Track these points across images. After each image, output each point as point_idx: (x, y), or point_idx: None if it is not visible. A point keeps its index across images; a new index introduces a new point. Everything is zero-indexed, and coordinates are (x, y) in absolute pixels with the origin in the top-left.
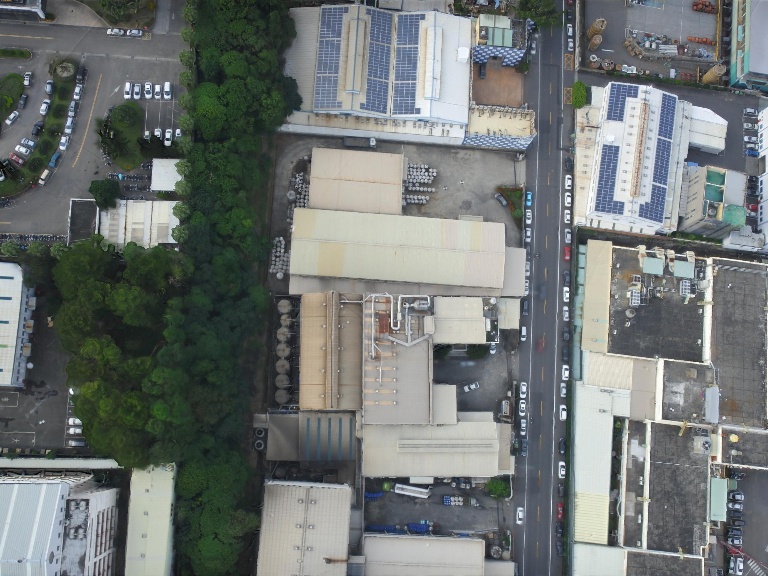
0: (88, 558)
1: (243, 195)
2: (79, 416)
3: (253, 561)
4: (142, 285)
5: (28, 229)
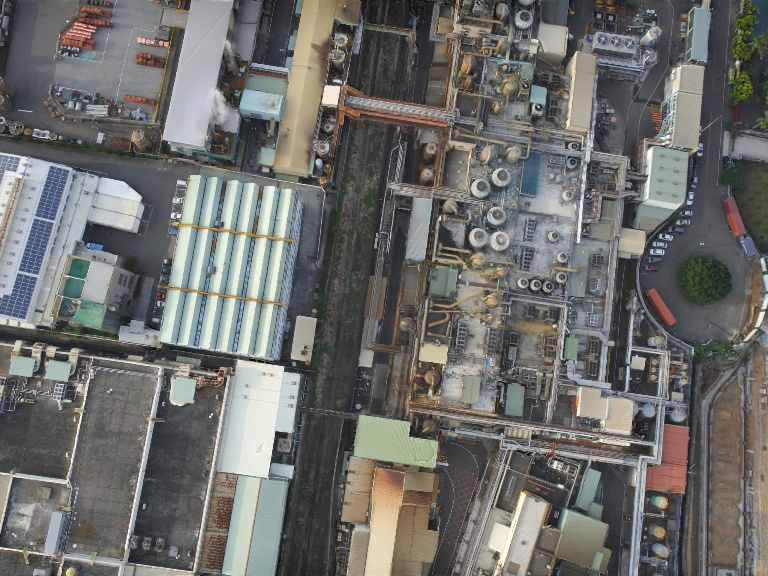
0: None
1: None
2: None
3: None
4: None
5: None
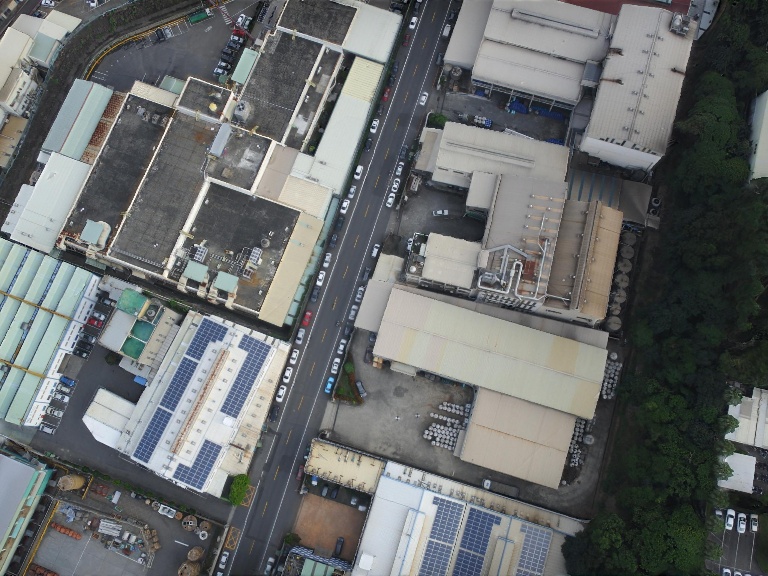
0: None
1: (654, 435)
2: None
3: None
4: None
5: None
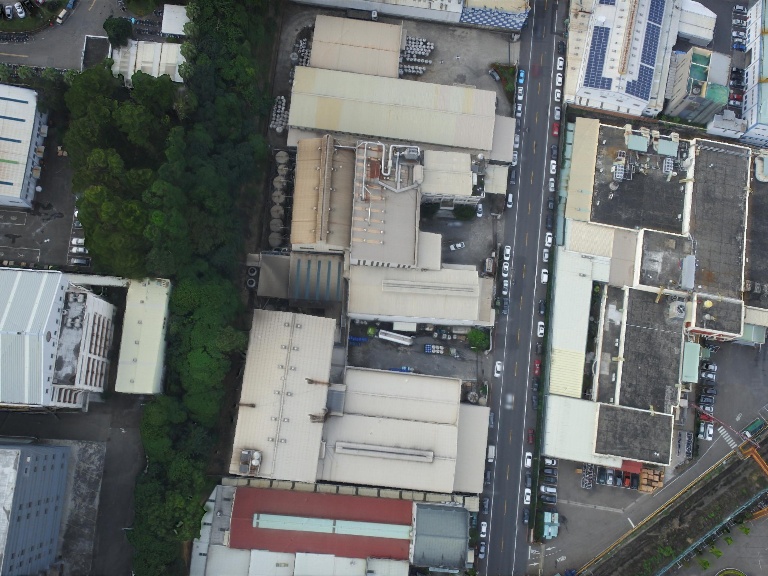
0: (83, 347)
1: (248, 45)
2: (82, 220)
3: (240, 392)
4: (148, 107)
5: (44, 63)
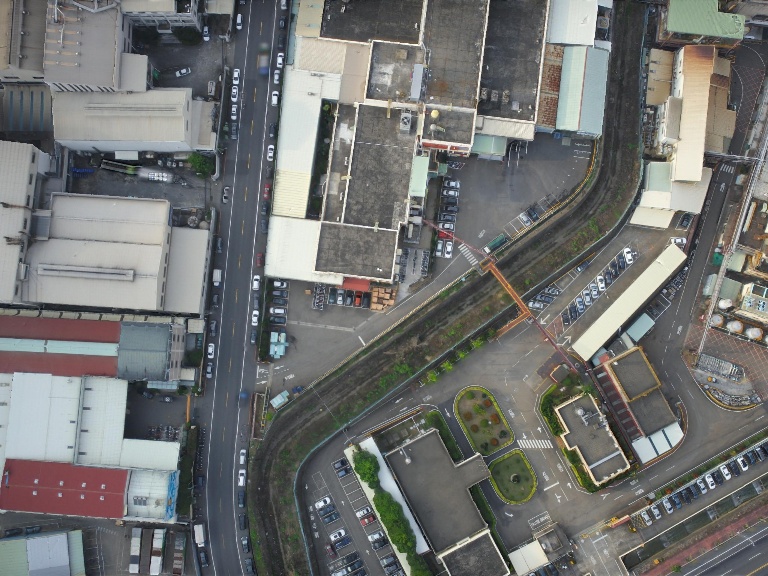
0: None
1: None
2: None
3: None
4: None
5: None
